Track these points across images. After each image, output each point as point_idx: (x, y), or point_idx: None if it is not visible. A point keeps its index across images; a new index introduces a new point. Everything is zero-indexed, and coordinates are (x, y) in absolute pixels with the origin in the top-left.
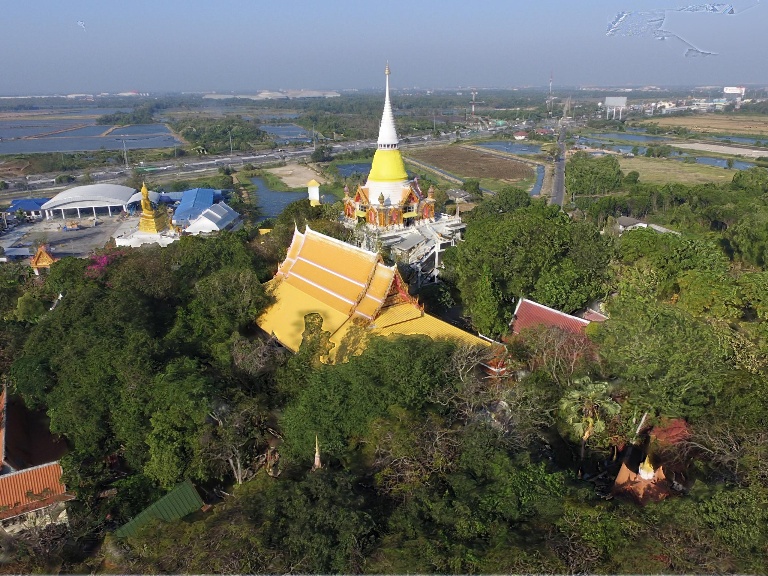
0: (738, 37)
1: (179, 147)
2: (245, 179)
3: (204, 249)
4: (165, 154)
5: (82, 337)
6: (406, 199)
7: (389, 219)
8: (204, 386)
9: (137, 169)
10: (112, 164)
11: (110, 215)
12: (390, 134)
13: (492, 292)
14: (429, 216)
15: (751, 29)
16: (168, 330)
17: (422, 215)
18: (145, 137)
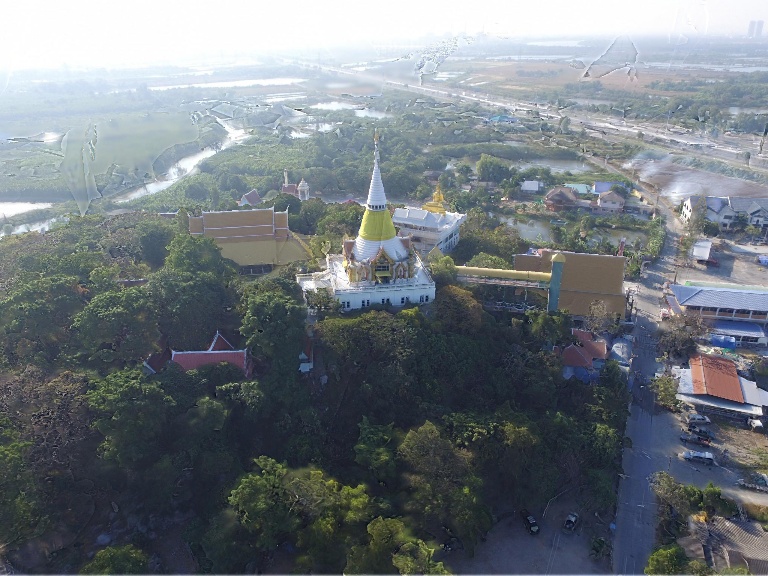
0: (23, 132)
1: None
2: None
3: None
4: None
5: None
6: None
7: None
8: None
9: None
10: None
11: None
12: None
13: None
14: None
15: (18, 130)
16: None
17: None
18: None
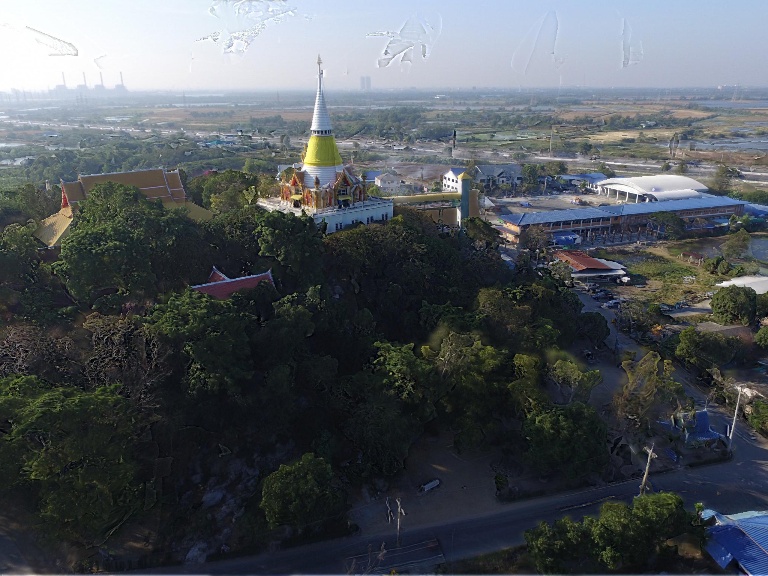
0: None
1: None
2: None
3: None
4: None
5: None
6: None
7: (285, 195)
8: (6, 192)
9: (724, 167)
10: None
11: None
12: None
13: (75, 220)
14: None
15: None
16: None
17: (309, 202)
18: None
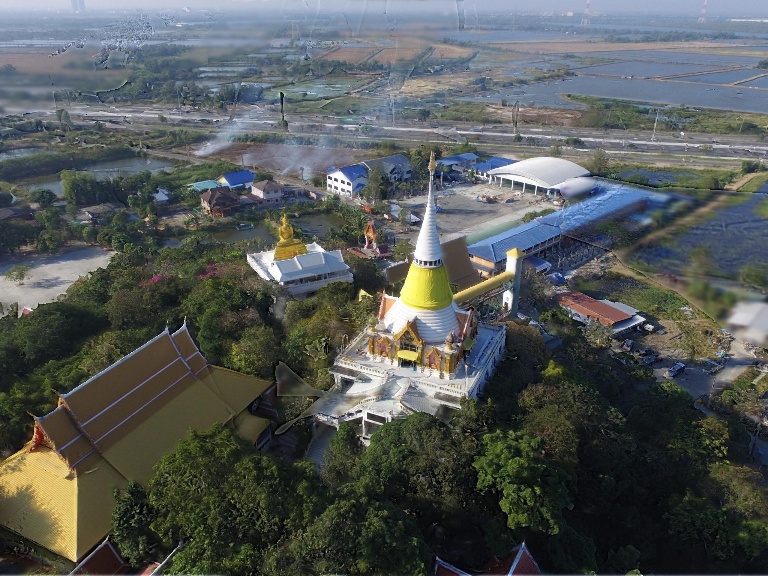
0: None
1: (750, 120)
2: (757, 184)
3: (200, 300)
4: (729, 126)
5: (2, 339)
6: (406, 334)
7: (379, 348)
8: None
9: (602, 151)
10: (658, 129)
11: (535, 194)
12: (421, 247)
13: (121, 509)
14: (443, 368)
15: None
16: (63, 359)
17: (431, 362)
18: (767, 94)
